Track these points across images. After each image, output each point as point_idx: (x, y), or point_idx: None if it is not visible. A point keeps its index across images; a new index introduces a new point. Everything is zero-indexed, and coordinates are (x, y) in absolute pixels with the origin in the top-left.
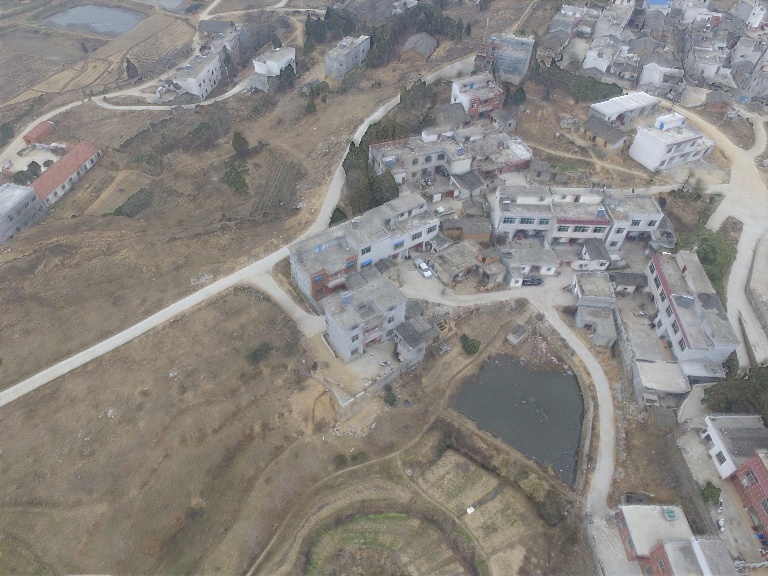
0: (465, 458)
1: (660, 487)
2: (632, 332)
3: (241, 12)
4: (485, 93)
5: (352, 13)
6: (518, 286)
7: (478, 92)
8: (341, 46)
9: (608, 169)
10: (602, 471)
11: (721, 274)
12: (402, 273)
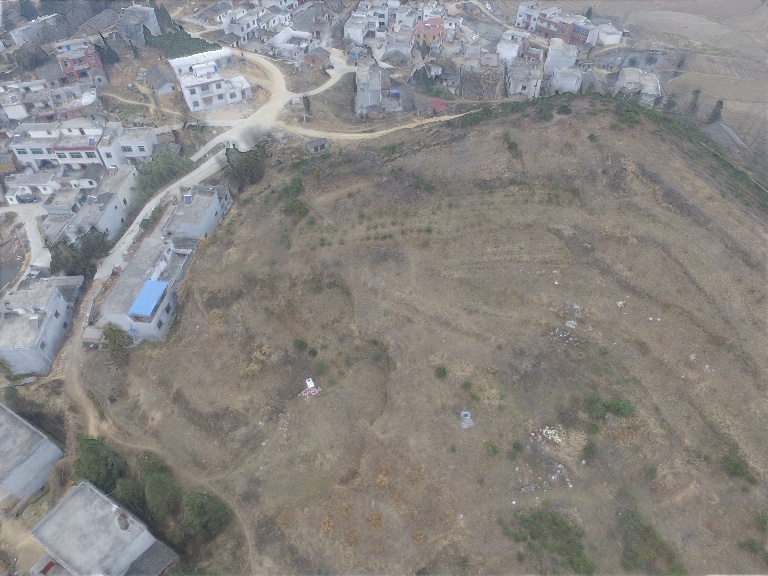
0: None
1: None
2: None
3: (9, 1)
4: (81, 53)
5: None
6: (16, 203)
7: (75, 53)
8: None
9: (157, 111)
10: None
11: (154, 182)
12: None
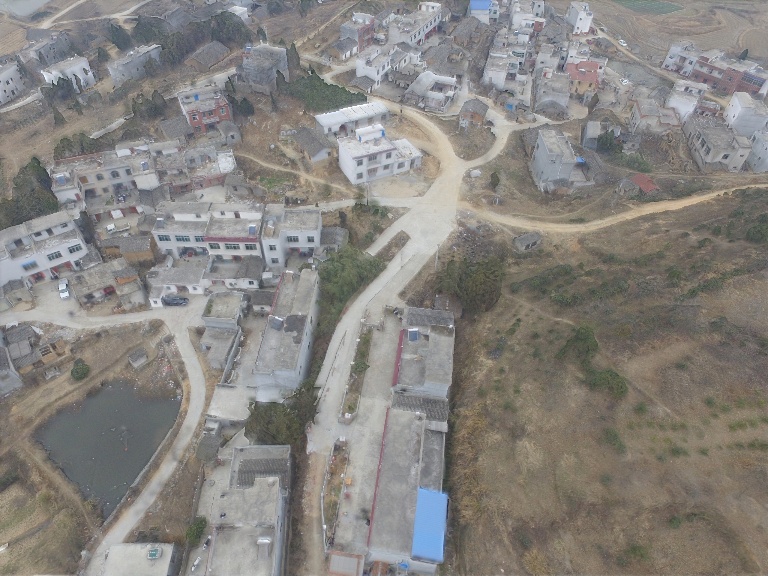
0: (28, 490)
1: (176, 522)
2: (249, 354)
3: (85, 20)
4: (210, 104)
5: (164, 21)
6: (160, 306)
7: (204, 103)
8: (130, 55)
9: (310, 182)
10: (139, 504)
11: (343, 293)
12: (42, 294)
